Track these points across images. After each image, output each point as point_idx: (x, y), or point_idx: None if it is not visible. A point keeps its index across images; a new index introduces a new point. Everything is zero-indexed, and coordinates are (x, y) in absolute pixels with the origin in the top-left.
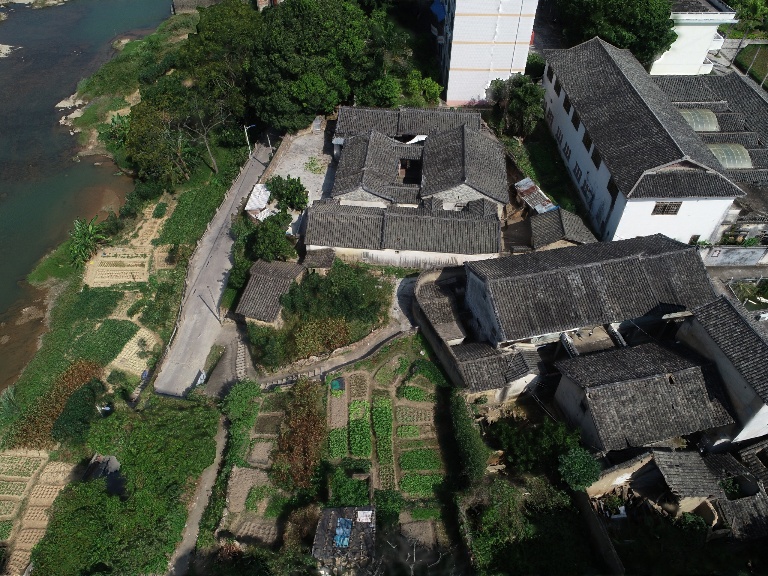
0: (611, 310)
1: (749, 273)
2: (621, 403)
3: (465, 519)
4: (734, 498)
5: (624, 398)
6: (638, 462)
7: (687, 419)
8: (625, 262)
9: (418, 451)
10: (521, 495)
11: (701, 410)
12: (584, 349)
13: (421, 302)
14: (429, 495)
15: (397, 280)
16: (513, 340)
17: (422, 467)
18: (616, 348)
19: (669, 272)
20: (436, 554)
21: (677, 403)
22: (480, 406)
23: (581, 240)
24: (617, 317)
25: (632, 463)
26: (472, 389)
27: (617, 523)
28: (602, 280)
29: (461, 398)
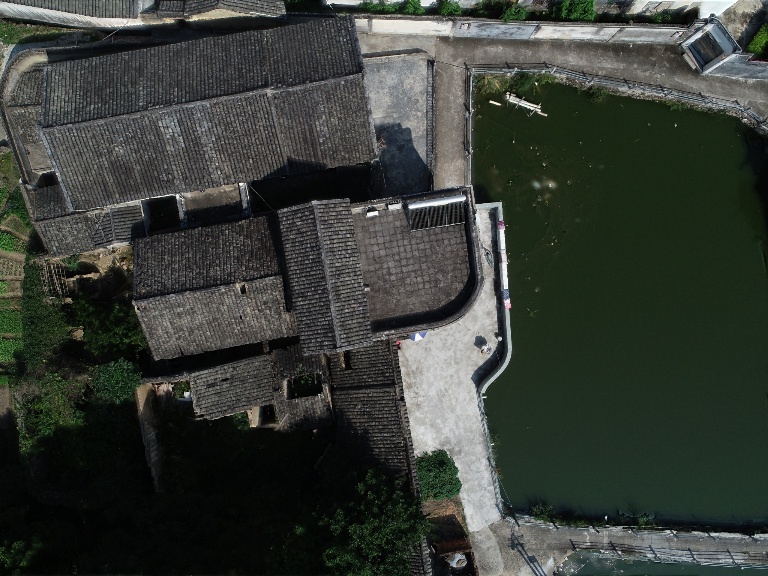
0: (218, 171)
1: (511, 54)
2: (176, 315)
3: (19, 404)
4: (302, 391)
5: (180, 310)
6: (177, 380)
7: (256, 329)
8: (246, 100)
9: (3, 312)
10: (79, 383)
11: (274, 320)
12: (200, 203)
13: (11, 110)
14: (10, 360)
15: (6, 48)
16: (84, 209)
17: (5, 331)
18: (240, 204)
19: (314, 113)
20: (10, 417)
21: (245, 314)
22: (87, 254)
23: (249, 8)
24: (225, 181)
25: (172, 380)
26: (53, 253)
27: (185, 402)
28: (209, 128)
29: (34, 268)
